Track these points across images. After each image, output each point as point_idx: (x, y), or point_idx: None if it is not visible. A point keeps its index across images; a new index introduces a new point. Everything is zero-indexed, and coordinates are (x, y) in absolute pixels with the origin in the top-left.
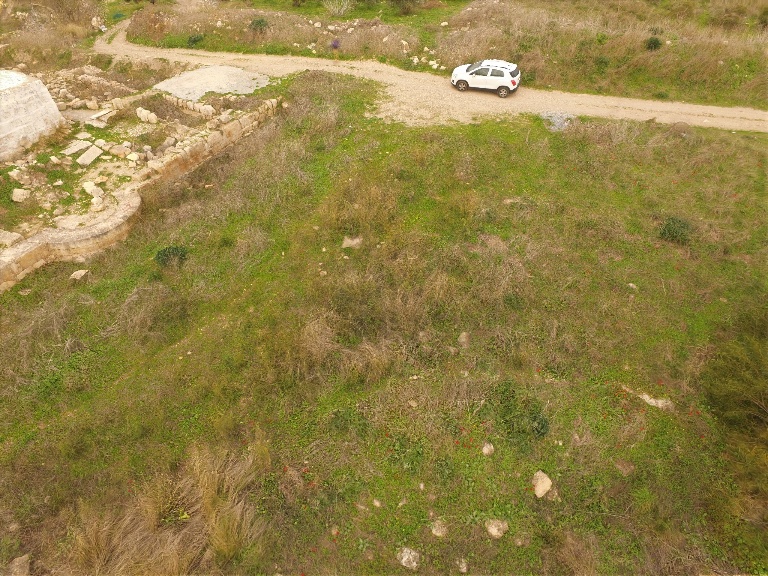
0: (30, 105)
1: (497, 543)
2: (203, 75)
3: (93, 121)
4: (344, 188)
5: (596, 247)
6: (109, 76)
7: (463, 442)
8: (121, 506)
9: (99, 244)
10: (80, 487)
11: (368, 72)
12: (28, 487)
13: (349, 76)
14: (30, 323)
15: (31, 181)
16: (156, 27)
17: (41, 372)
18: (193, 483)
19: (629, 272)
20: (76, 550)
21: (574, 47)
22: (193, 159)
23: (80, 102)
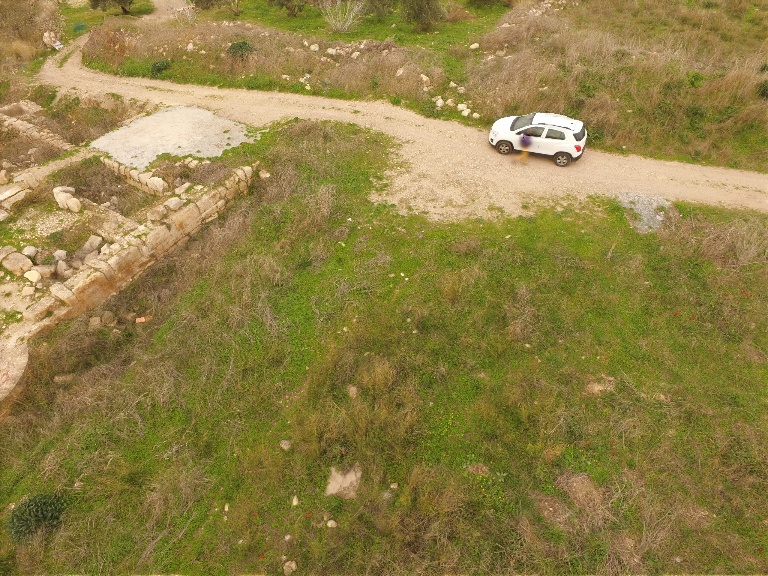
0: None
1: None
2: (160, 124)
3: None
4: (334, 356)
5: (764, 513)
6: (50, 116)
7: None
8: None
9: None
10: None
11: (377, 120)
12: None
13: (351, 126)
14: None
15: None
16: (116, 48)
17: None
18: None
19: None
20: None
21: (656, 91)
22: (123, 272)
23: None
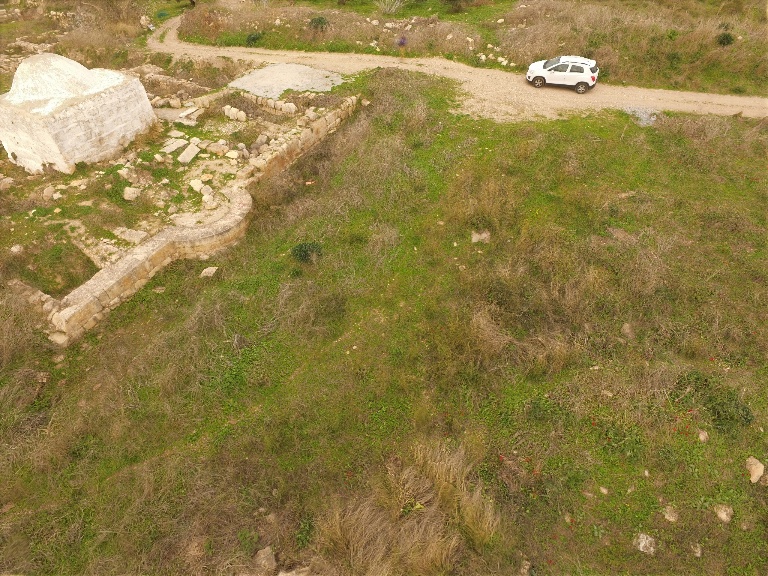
0: (130, 103)
1: (728, 527)
2: (274, 73)
3: (183, 119)
4: (458, 184)
5: (725, 239)
6: (171, 75)
7: (678, 429)
8: (341, 498)
9: (221, 241)
10: (294, 480)
11: (438, 69)
12: (244, 481)
13: (419, 73)
14: (194, 320)
15: (138, 179)
16: (210, 26)
17: (217, 368)
18: (416, 474)
19: (766, 263)
20: (324, 541)
21: (645, 43)
22: (288, 156)
23: (162, 101)
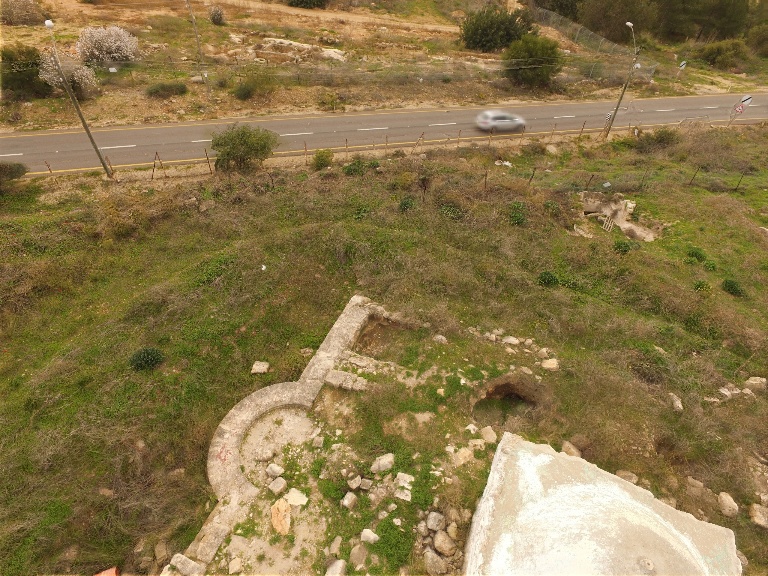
0: None
1: None
2: None
3: None
4: None
5: None
6: None
7: None
8: None
9: None
10: None
11: None
12: None
13: None
14: None
15: None
16: None
17: None
18: None
19: None
20: None
21: None
22: None
23: None
